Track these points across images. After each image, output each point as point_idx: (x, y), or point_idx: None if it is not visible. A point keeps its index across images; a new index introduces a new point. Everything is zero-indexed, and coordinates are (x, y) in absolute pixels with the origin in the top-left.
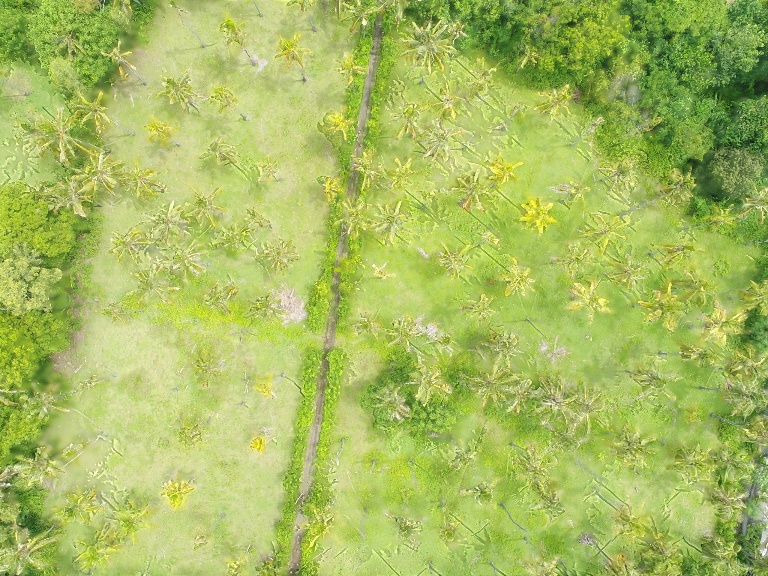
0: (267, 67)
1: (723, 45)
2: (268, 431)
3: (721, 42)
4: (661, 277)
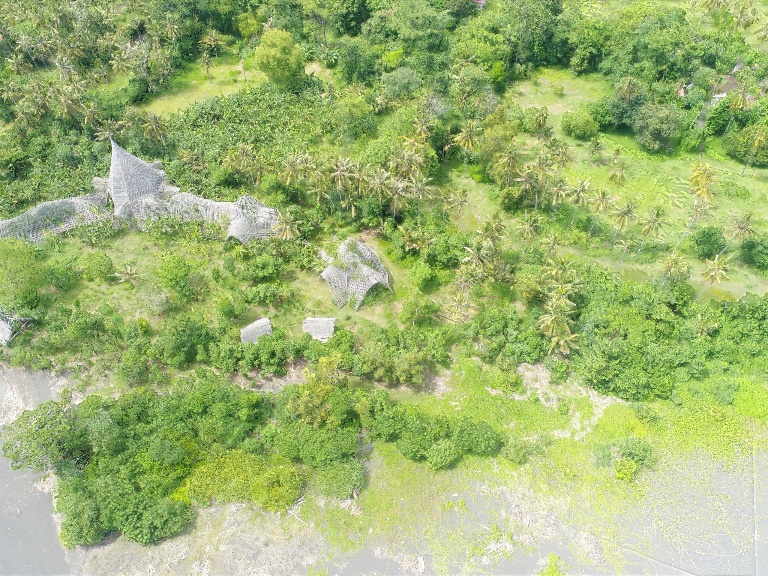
0: None
1: (573, 18)
2: None
3: (574, 19)
4: None
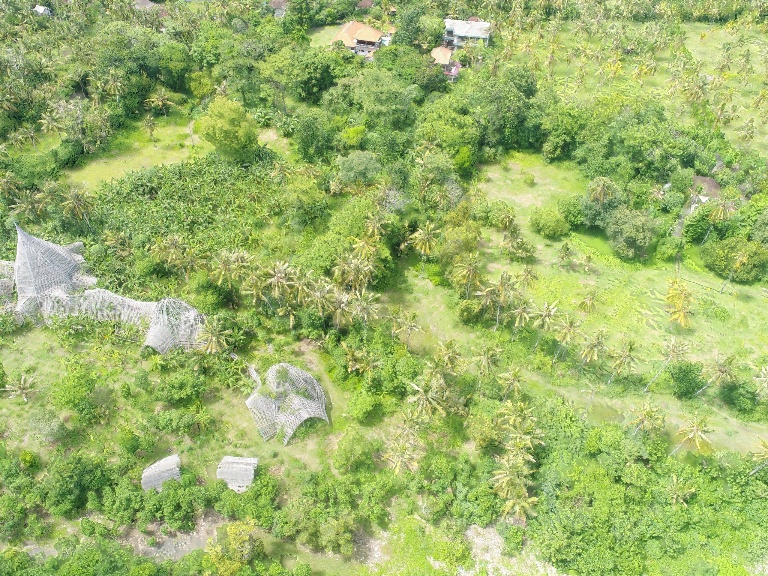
0: (764, 136)
1: (547, 102)
2: (696, 52)
3: None
4: (538, 79)
